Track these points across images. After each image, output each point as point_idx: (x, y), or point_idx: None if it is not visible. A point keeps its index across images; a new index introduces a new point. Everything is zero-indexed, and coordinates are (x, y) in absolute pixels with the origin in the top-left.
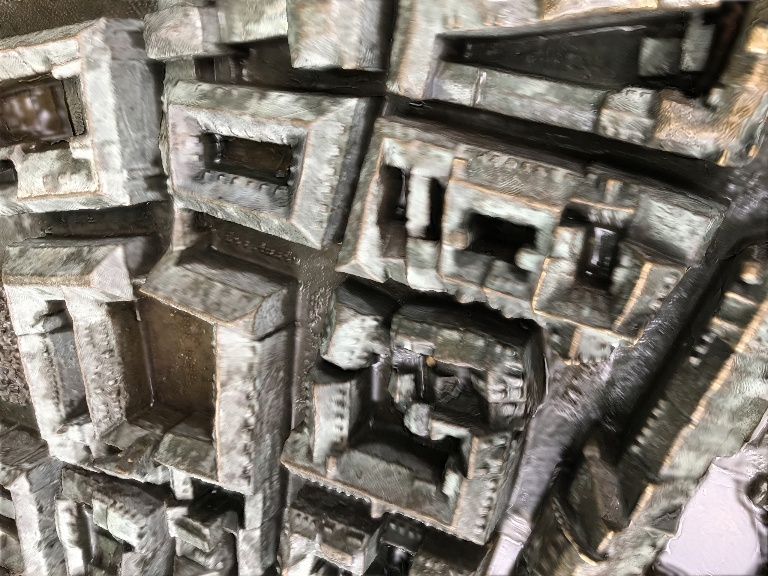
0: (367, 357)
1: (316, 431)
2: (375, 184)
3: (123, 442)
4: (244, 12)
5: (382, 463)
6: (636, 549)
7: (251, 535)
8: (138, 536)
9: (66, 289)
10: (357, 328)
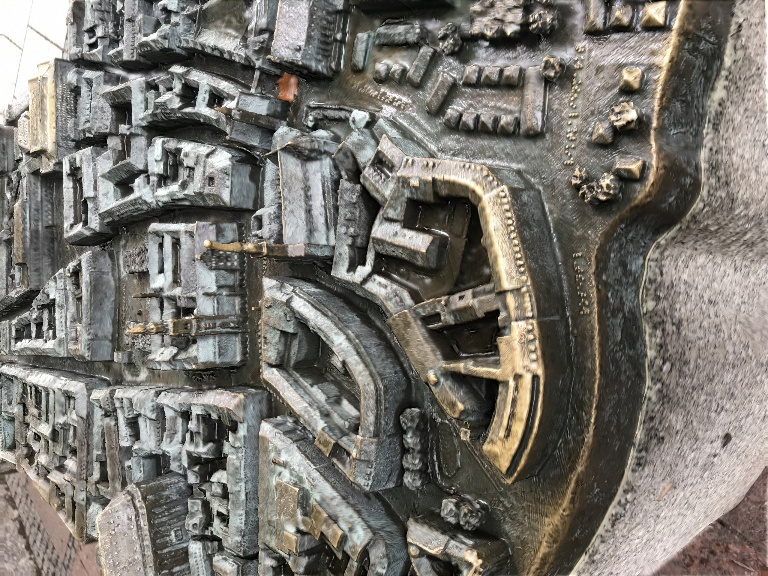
0: None
1: (119, 50)
2: None
3: None
4: None
5: None
6: None
7: None
8: None
9: None
10: None
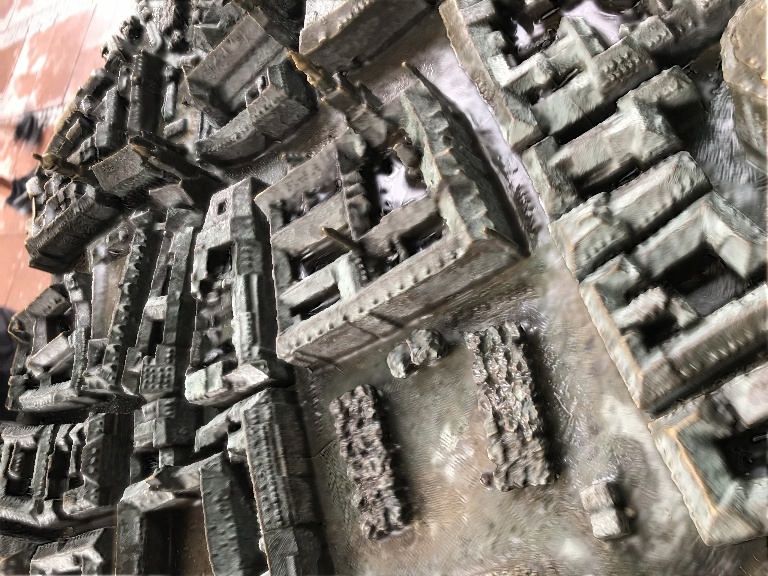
0: None
1: None
2: None
3: (187, 477)
4: None
5: (69, 569)
6: None
7: None
8: None
9: None
10: None
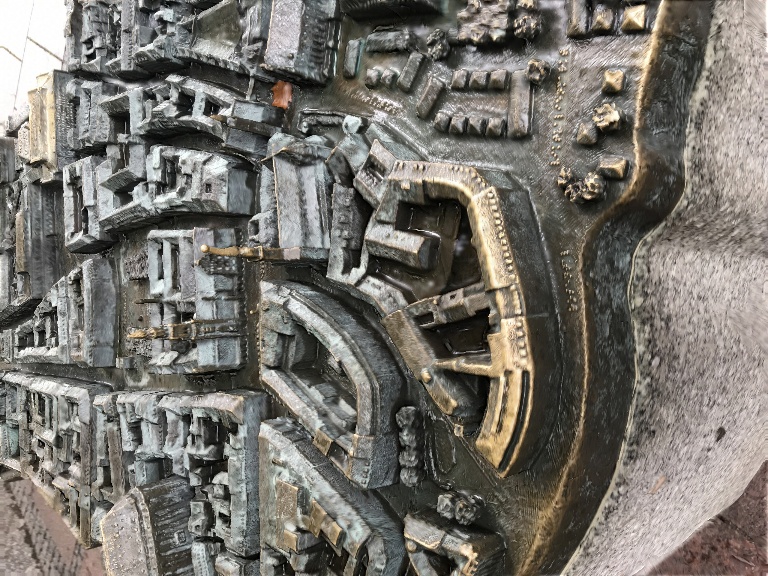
0: None
1: (116, 60)
2: None
3: None
4: None
5: None
6: None
7: None
8: None
9: None
10: None
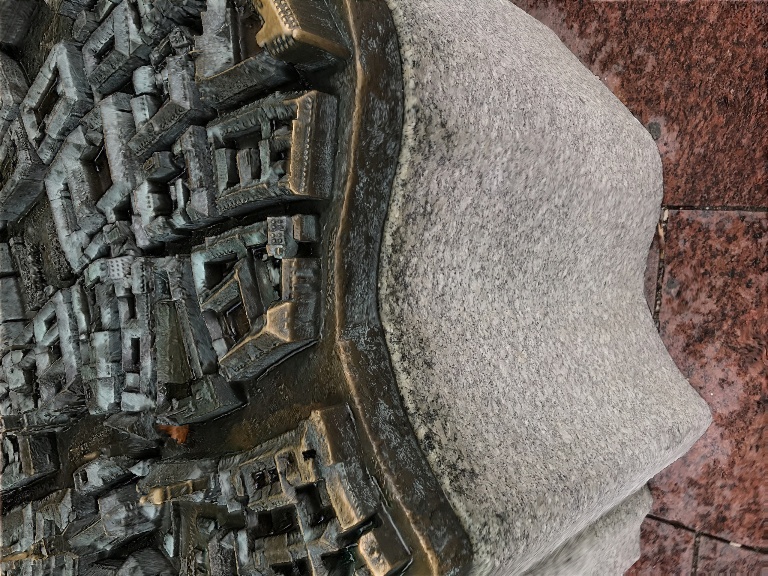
0: (153, 86)
1: (134, 118)
2: (128, 9)
3: None
4: (101, 8)
5: None
6: (218, 49)
7: (139, 220)
8: (100, 268)
9: (62, 155)
10: (143, 72)
